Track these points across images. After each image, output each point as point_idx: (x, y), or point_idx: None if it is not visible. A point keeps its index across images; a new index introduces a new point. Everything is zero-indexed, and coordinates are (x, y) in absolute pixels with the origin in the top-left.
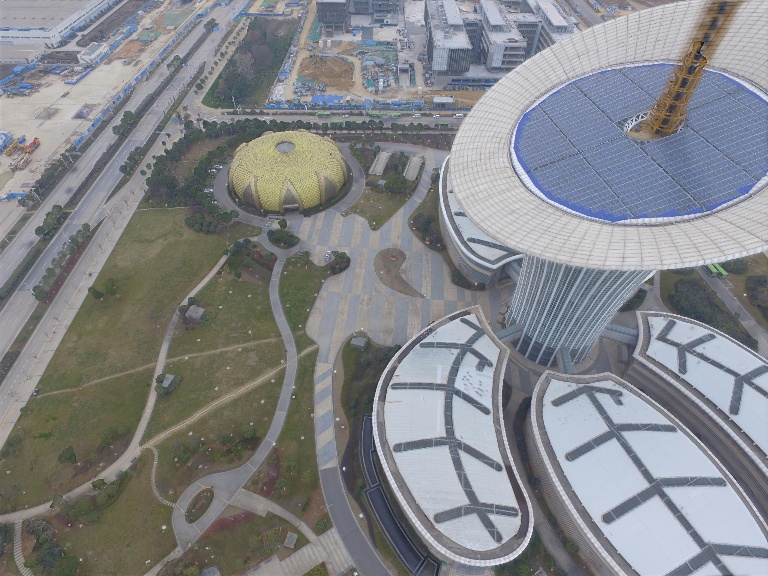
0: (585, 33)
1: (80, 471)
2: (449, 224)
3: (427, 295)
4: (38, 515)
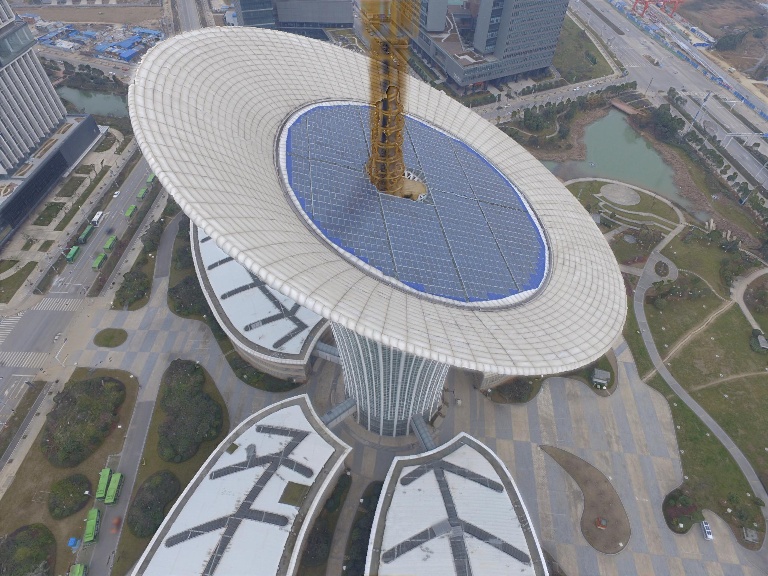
0: (447, 349)
1: (763, 288)
2: (535, 535)
3: (536, 449)
4: (762, 268)
